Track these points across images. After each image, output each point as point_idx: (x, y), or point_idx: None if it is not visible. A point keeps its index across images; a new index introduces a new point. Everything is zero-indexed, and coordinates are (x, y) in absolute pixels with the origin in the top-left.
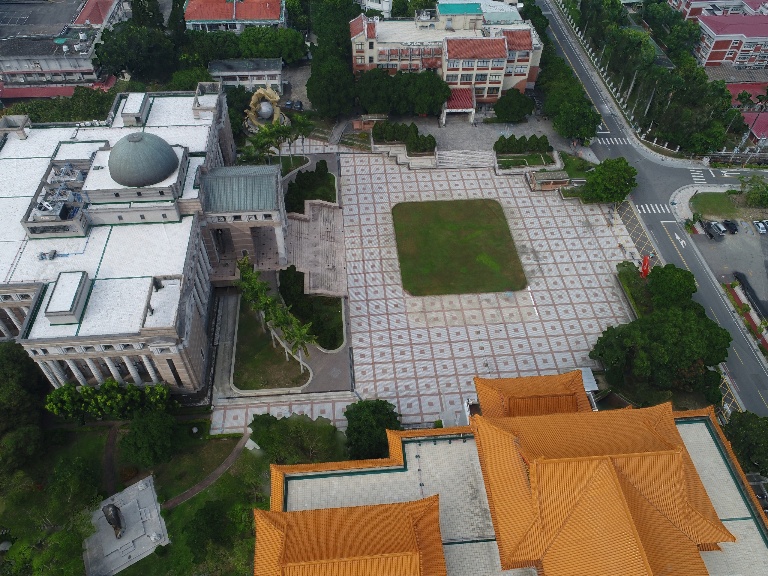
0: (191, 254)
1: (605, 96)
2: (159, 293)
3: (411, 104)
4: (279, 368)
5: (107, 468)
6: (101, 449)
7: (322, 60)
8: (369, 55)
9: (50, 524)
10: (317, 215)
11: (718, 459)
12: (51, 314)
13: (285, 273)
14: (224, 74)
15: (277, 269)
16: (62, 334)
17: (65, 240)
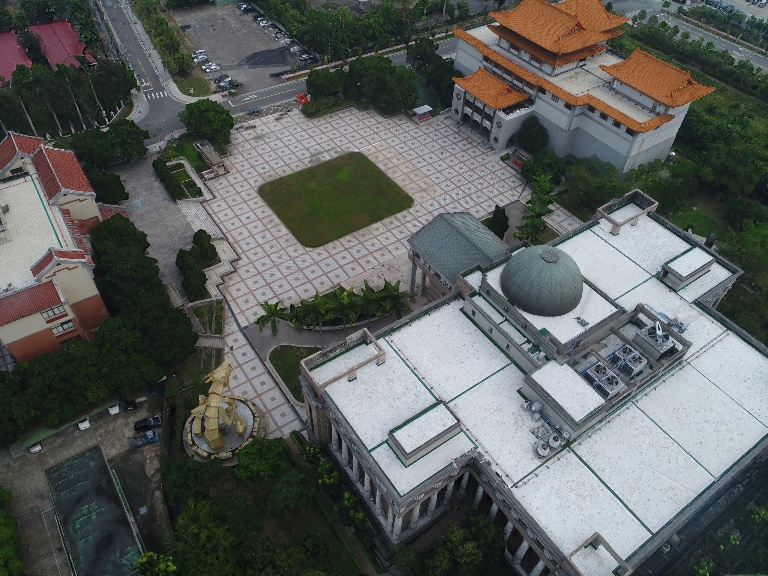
0: None
1: None
2: None
3: None
4: (543, 238)
5: None
6: None
7: (73, 373)
8: None
9: None
10: None
11: None
12: None
13: None
14: None
15: None
16: None
17: None
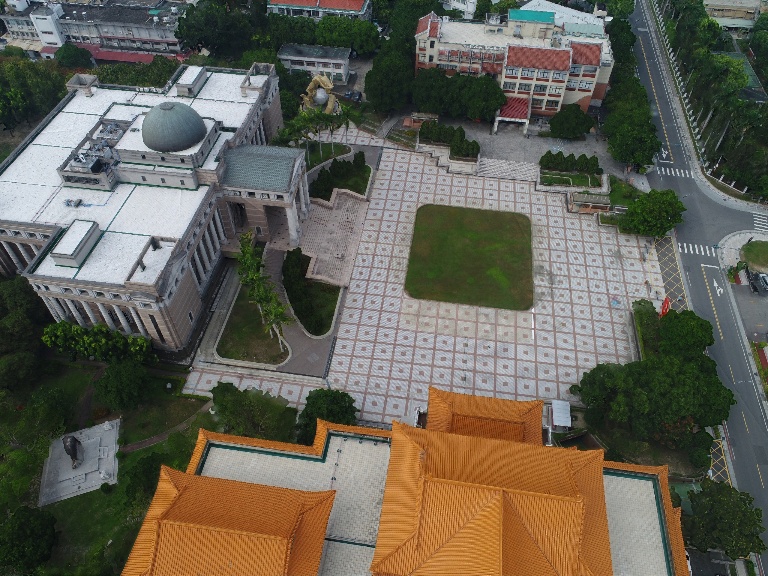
0: (197, 221)
1: (680, 124)
2: (156, 252)
3: (464, 107)
4: (262, 343)
5: (85, 404)
6: (85, 386)
7: (386, 54)
8: (429, 54)
9: (16, 442)
10: (342, 204)
11: (654, 522)
12: (55, 255)
13: (291, 254)
14: (292, 58)
15: (286, 249)
16: (62, 275)
17: (93, 192)
